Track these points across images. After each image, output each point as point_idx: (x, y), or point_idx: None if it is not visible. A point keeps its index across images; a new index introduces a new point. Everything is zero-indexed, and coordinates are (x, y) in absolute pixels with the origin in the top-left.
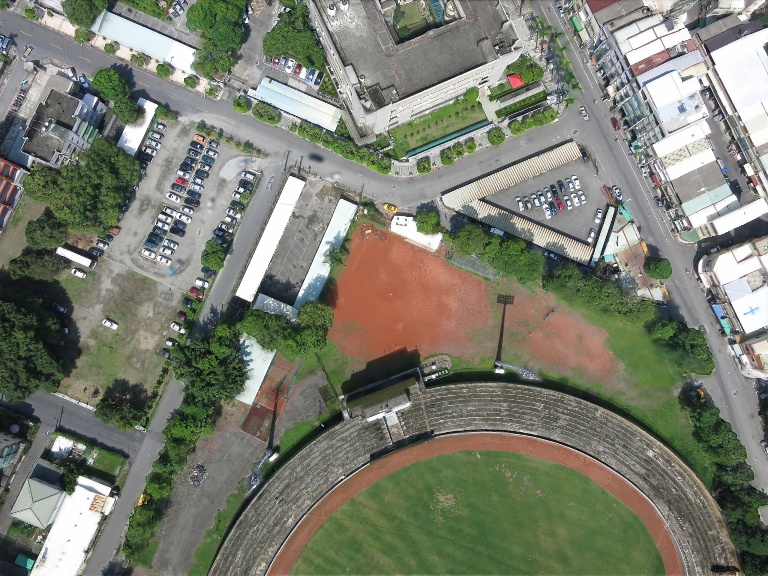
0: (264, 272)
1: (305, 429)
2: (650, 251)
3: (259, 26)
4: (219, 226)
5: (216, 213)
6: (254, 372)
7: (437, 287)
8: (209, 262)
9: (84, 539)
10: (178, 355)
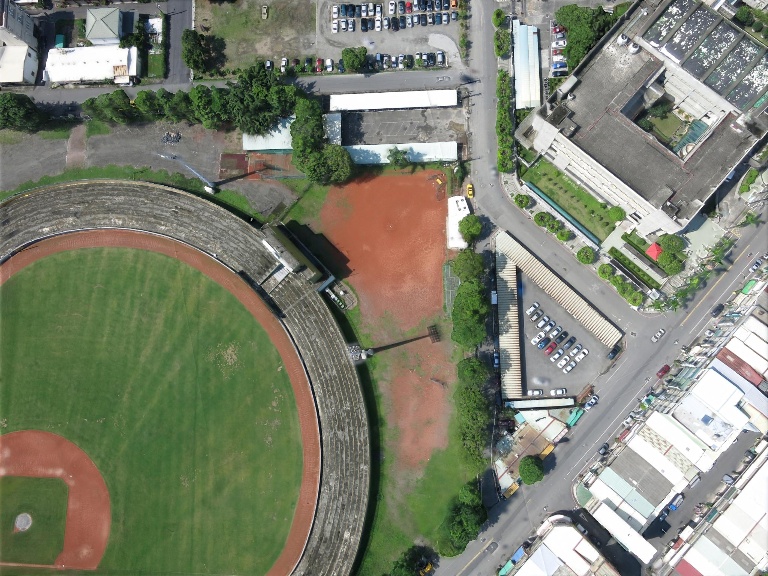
0: (361, 108)
1: (243, 206)
2: (548, 460)
3: (583, 1)
4: (385, 55)
5: (395, 48)
6: (271, 139)
7: (417, 265)
8: (346, 55)
9: (90, 74)
10: (256, 66)
